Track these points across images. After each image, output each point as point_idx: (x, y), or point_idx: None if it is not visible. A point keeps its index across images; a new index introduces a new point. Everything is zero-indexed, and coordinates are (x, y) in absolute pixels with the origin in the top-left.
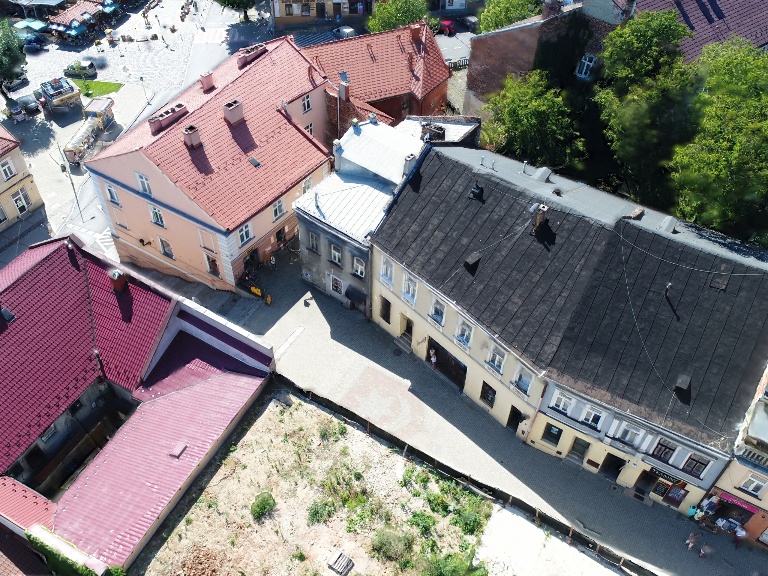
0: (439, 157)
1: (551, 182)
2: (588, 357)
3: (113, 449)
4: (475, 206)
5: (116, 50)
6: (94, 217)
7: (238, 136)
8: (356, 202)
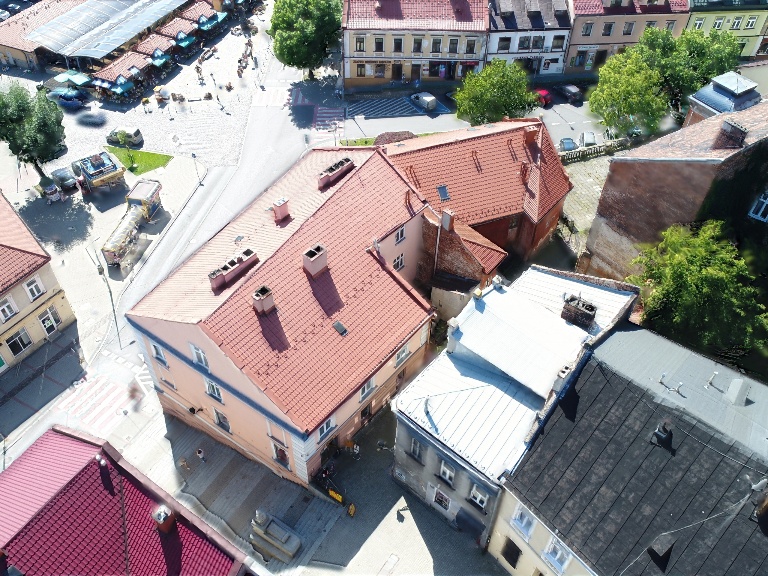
0: (603, 370)
1: (750, 402)
2: None
3: None
4: (660, 457)
5: (165, 111)
6: (134, 341)
7: (320, 292)
8: (480, 411)
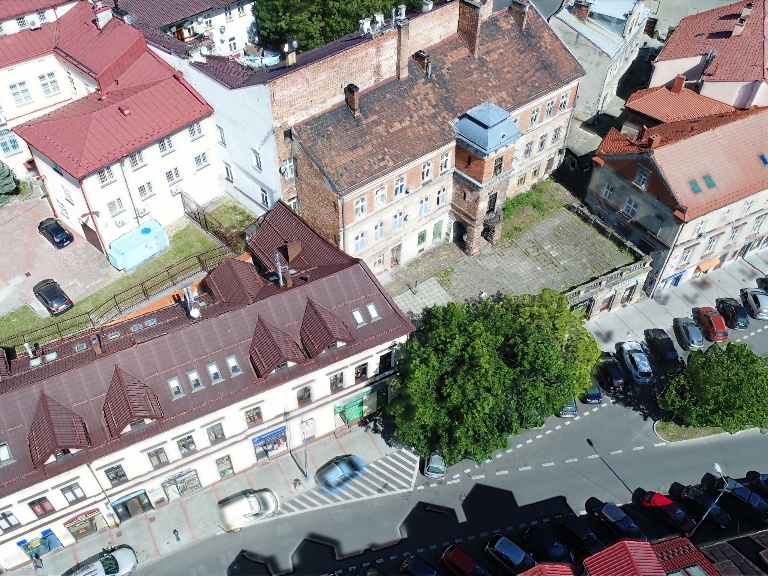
0: None
1: None
2: None
3: None
4: None
5: None
6: None
7: None
8: None
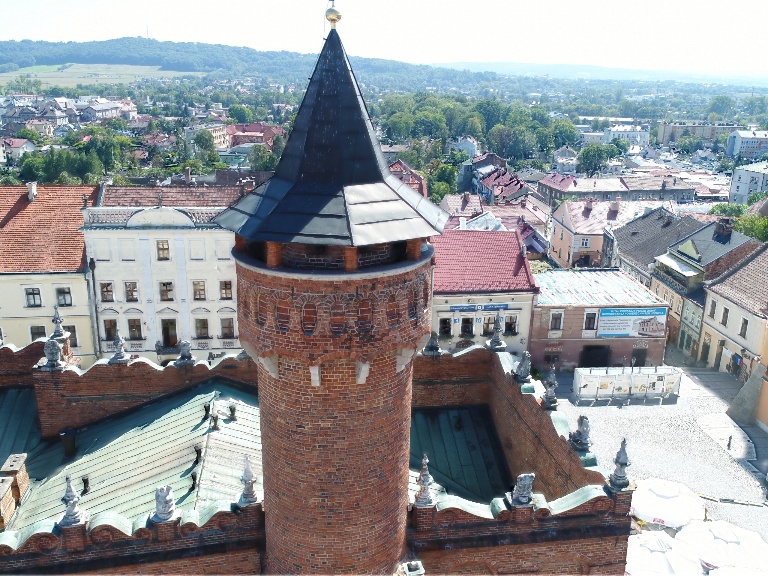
0: None
1: None
2: None
3: None
4: None
5: None
6: None
7: (610, 214)
8: None
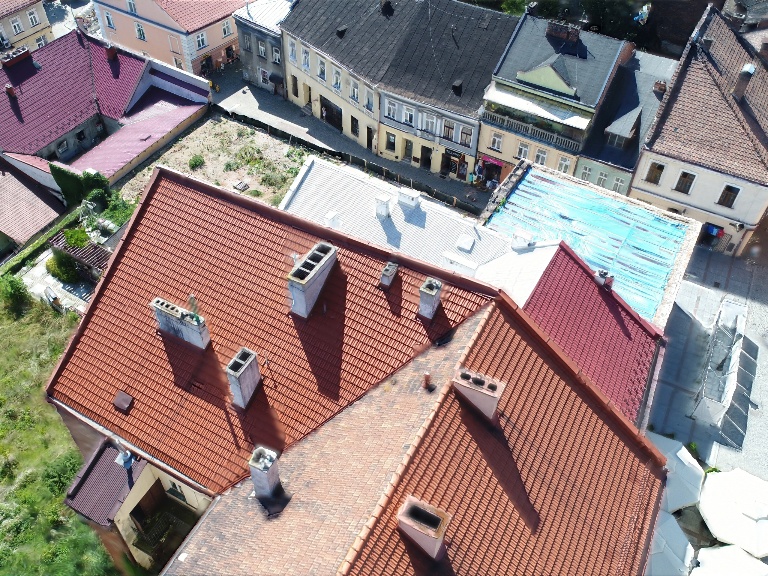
0: None
1: None
2: (404, 75)
3: (105, 144)
4: None
5: None
6: None
7: None
8: (275, 10)
